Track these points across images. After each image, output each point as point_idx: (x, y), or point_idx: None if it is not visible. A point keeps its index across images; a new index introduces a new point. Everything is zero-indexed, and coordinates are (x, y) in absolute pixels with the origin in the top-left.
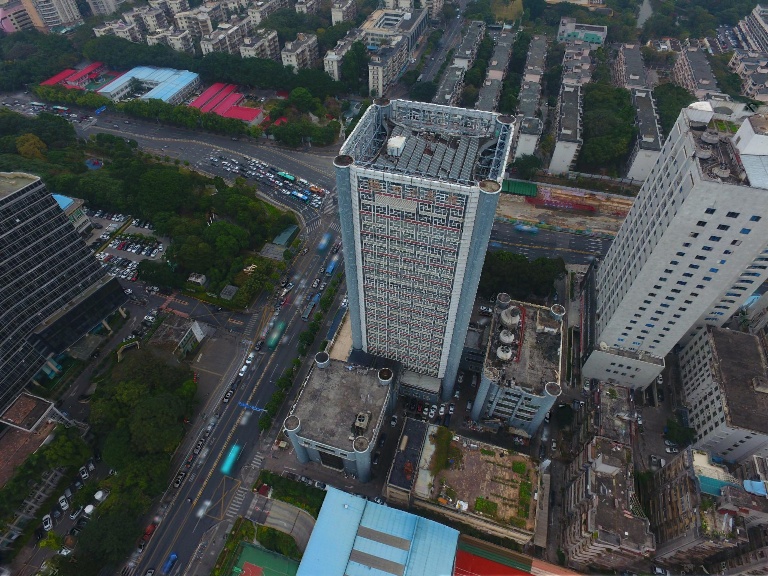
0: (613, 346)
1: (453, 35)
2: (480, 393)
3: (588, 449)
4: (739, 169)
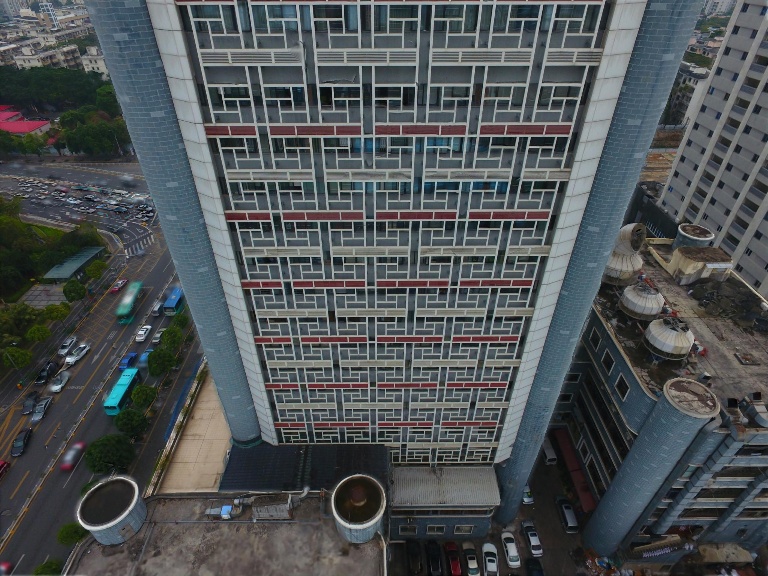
0: None
1: None
2: (644, 474)
3: None
4: None
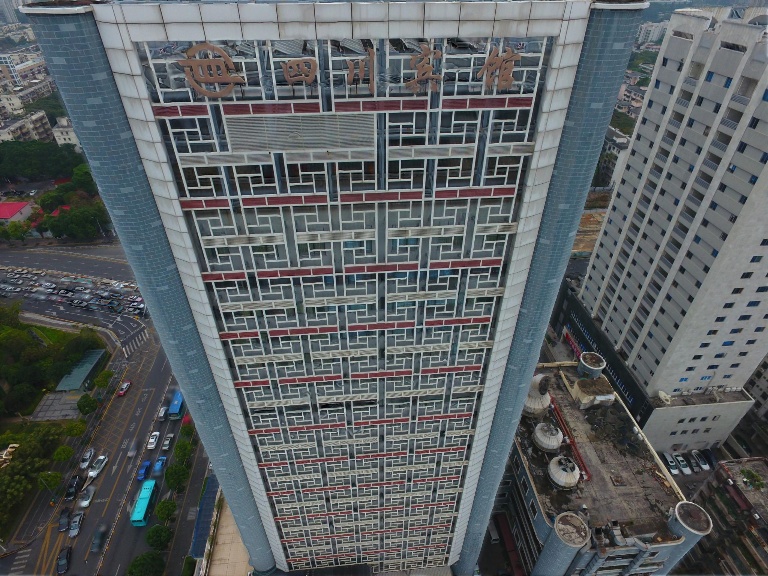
0: (672, 393)
1: None
2: (549, 574)
3: None
4: None
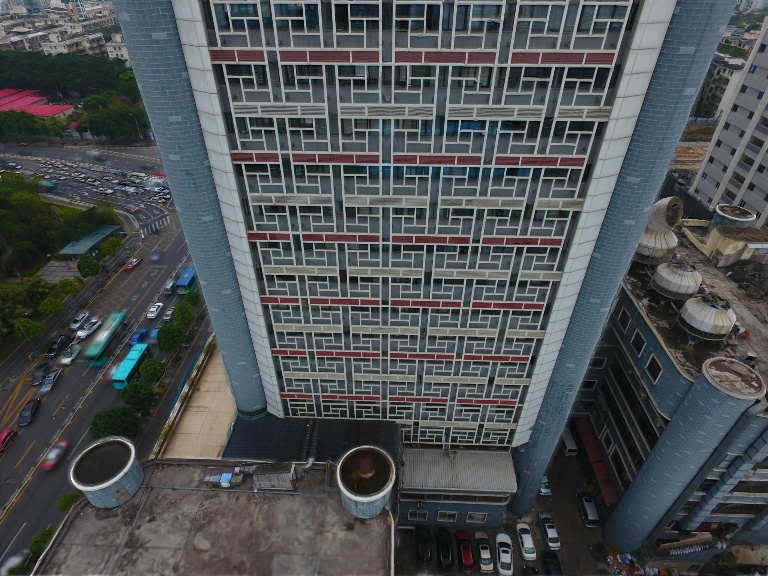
0: None
1: None
2: (677, 462)
3: None
4: None
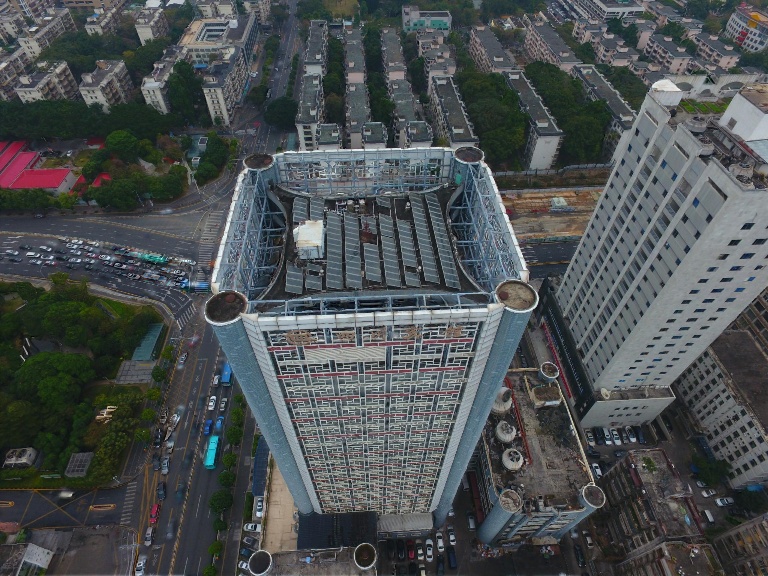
0: (613, 389)
1: (291, 39)
2: (495, 523)
3: (663, 567)
4: (757, 162)
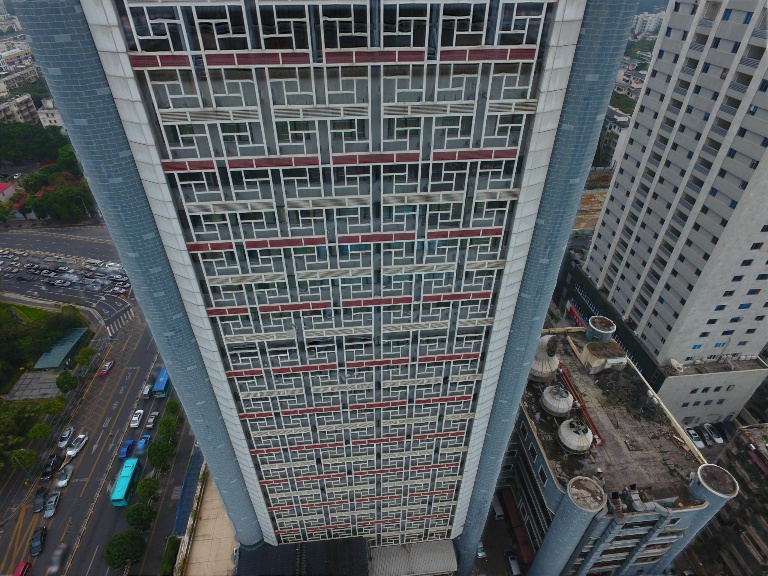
0: (684, 362)
1: None
2: (560, 545)
3: None
4: None
